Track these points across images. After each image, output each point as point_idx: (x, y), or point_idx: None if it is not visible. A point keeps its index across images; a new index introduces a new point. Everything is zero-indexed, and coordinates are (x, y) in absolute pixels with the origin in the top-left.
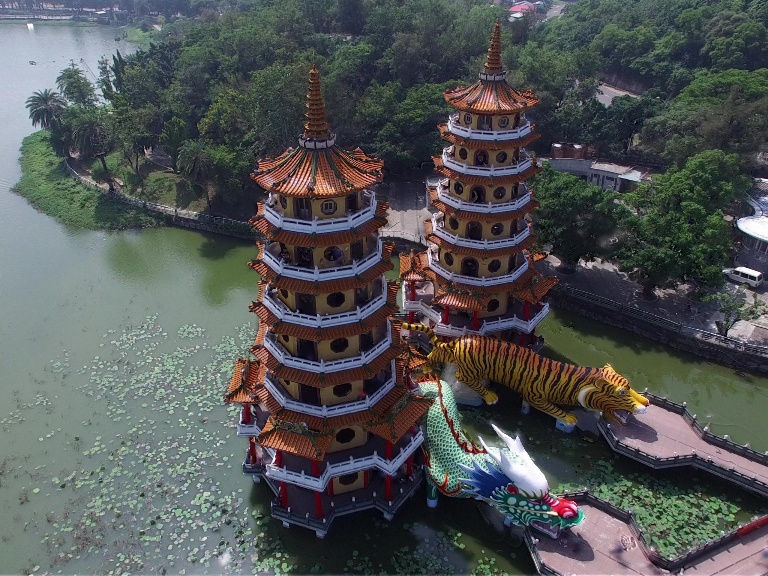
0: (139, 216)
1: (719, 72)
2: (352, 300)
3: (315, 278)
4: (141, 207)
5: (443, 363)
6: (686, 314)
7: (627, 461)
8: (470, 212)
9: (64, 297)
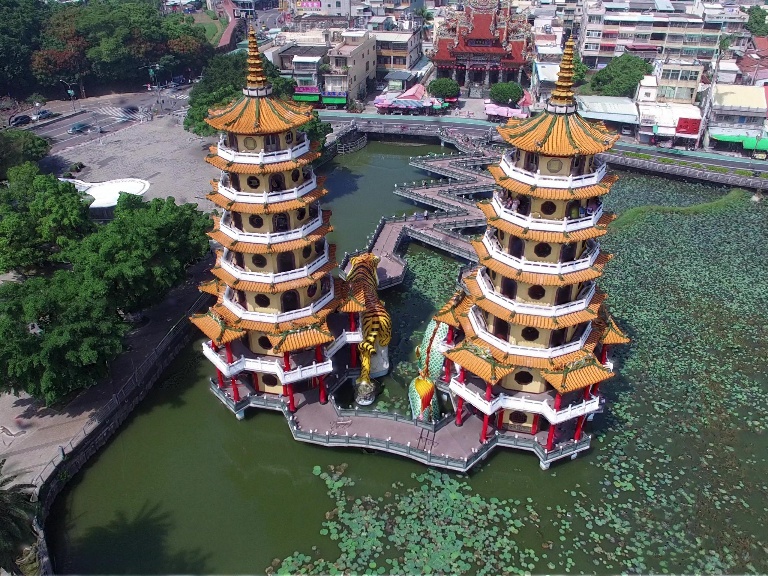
0: None
1: None
2: None
3: None
4: None
5: None
6: (213, 259)
7: None
8: None
9: None
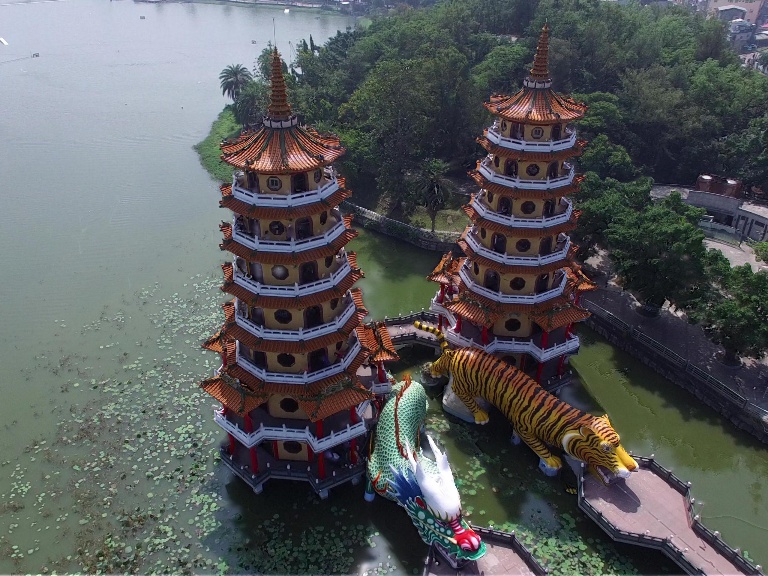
0: None
1: None
2: (297, 276)
3: (256, 247)
4: None
5: (448, 371)
6: None
7: (590, 523)
8: (493, 222)
9: (181, 240)
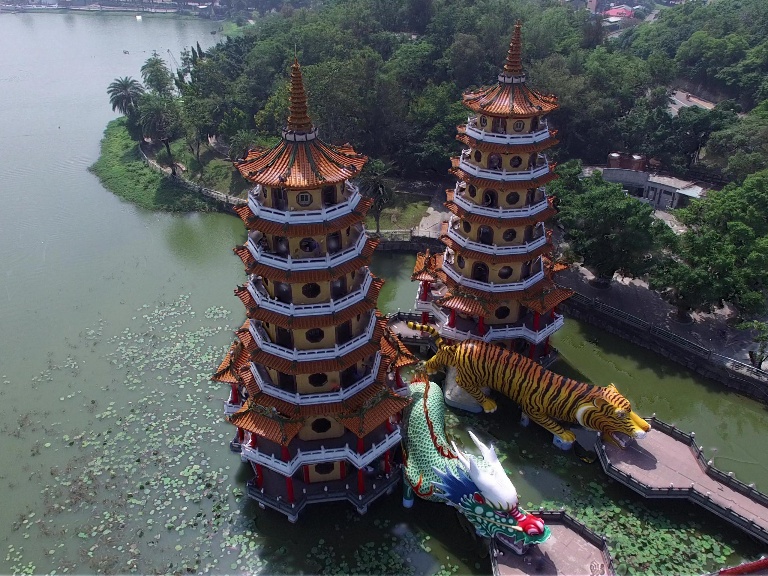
0: (194, 200)
1: None
2: (328, 292)
3: (288, 267)
4: (197, 192)
5: (446, 366)
6: (720, 341)
7: (619, 486)
8: (481, 216)
9: (111, 271)
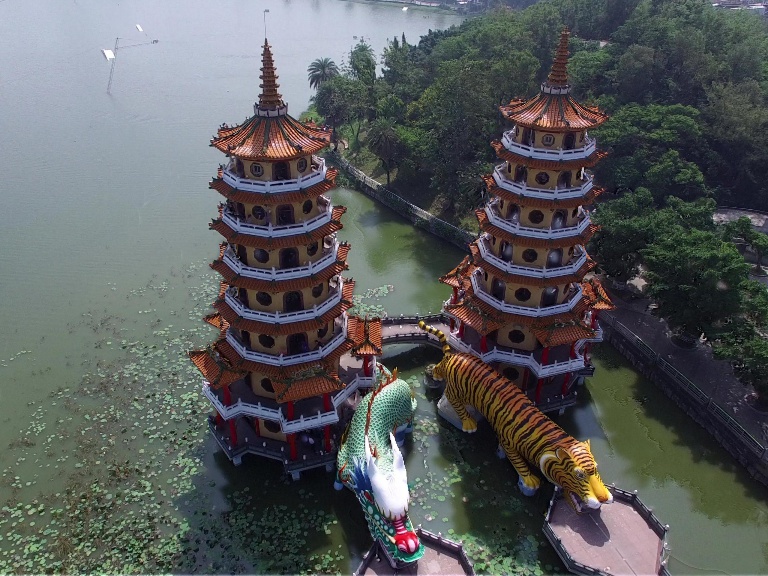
0: (340, 176)
1: None
2: (277, 261)
3: (238, 229)
4: (345, 169)
5: None
6: None
7: None
8: (499, 228)
9: None
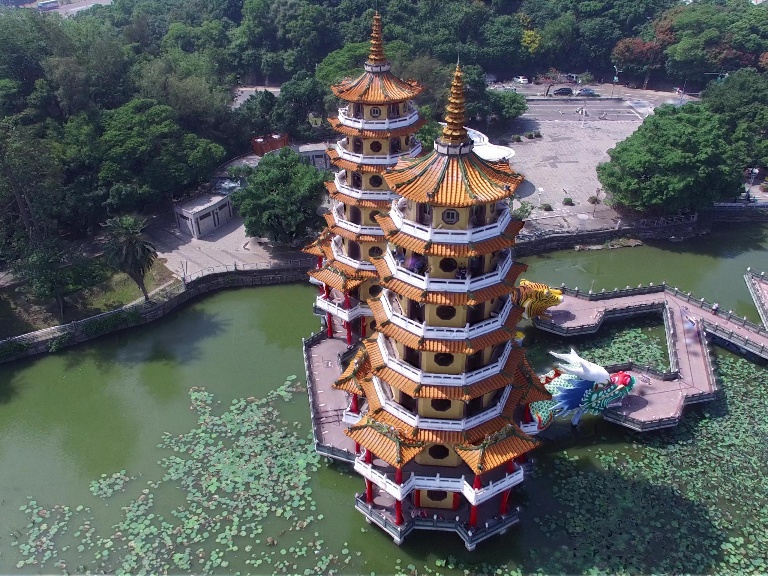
0: None
1: (340, 48)
2: None
3: (498, 279)
4: None
5: None
6: None
7: (576, 339)
8: None
9: None
